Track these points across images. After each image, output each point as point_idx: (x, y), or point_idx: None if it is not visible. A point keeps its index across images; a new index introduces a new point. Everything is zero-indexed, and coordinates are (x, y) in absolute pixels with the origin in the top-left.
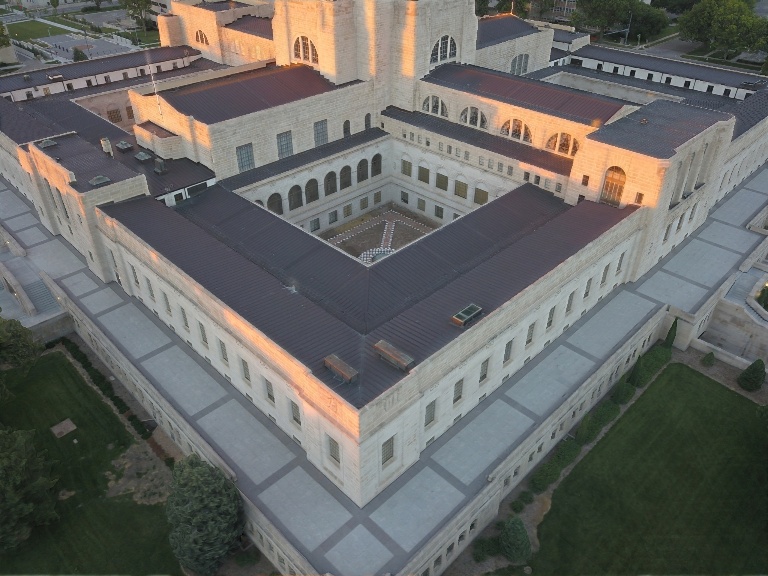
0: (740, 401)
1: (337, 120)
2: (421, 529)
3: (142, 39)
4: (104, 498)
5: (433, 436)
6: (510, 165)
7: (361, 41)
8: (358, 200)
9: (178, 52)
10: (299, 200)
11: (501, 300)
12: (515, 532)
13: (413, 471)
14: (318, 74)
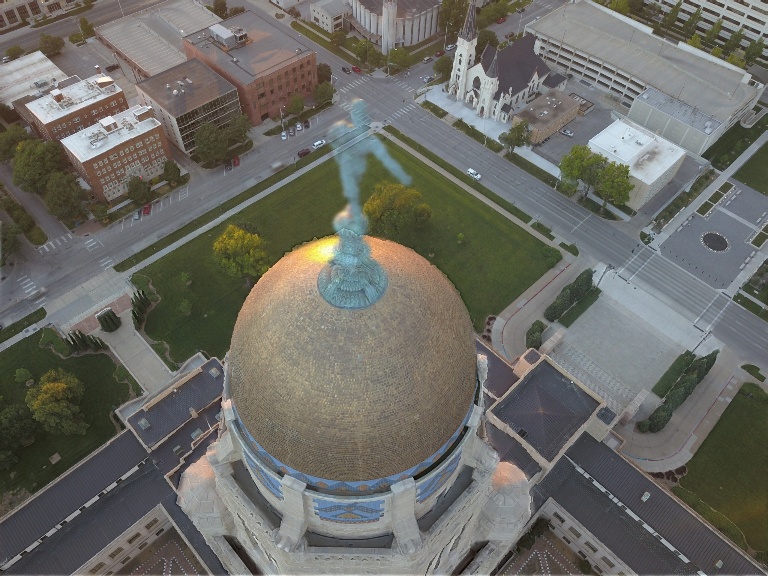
0: None
1: None
2: None
3: None
4: (4, 492)
5: None
6: None
7: None
8: None
9: (502, 382)
10: None
11: None
12: None
13: None
14: None
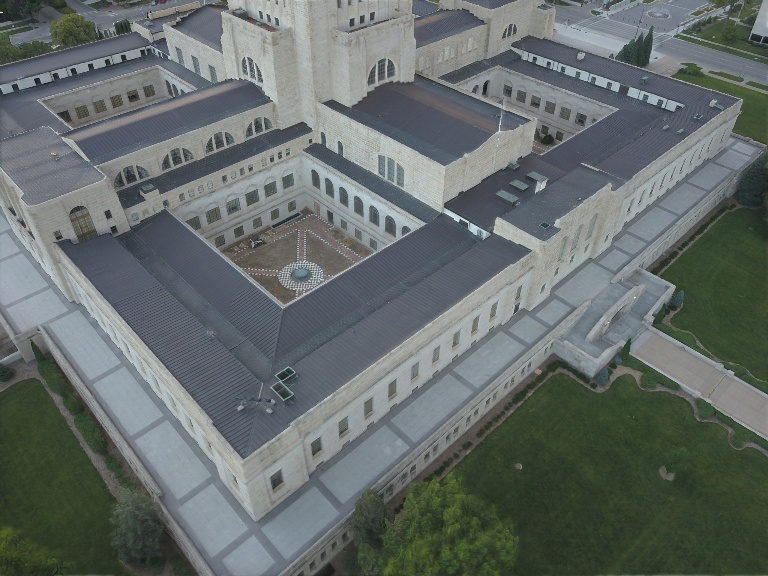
0: None
1: (221, 74)
2: None
3: None
4: None
5: None
6: None
7: None
8: None
9: None
10: None
11: None
12: None
13: None
14: None
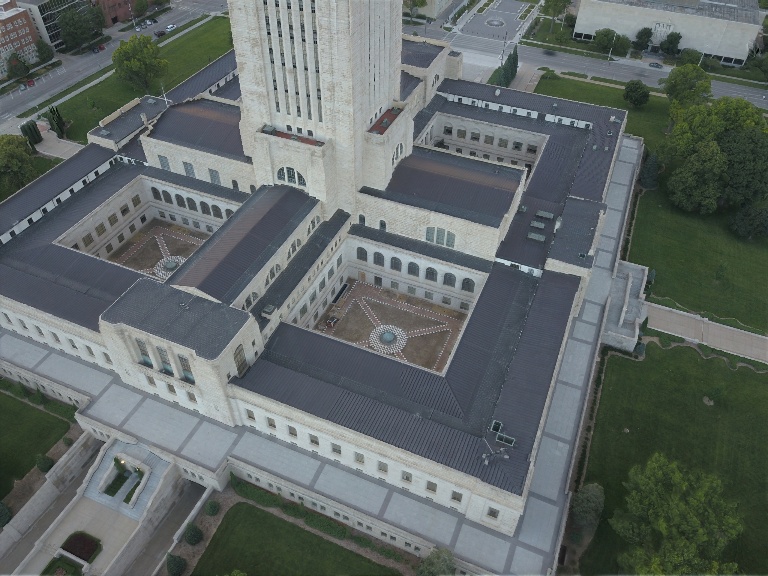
0: (32, 461)
1: (226, 176)
2: None
3: (540, 34)
4: None
5: None
6: None
7: None
8: None
9: None
10: None
11: None
12: None
13: None
14: None
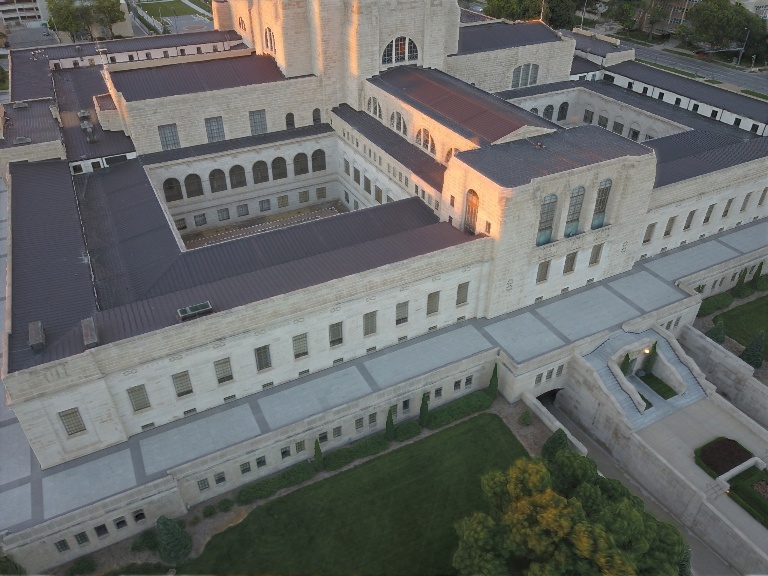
0: None
1: (278, 111)
2: (73, 502)
3: None
4: None
5: (152, 422)
6: (406, 176)
7: (313, 36)
8: (296, 193)
9: (223, 36)
10: (223, 184)
11: (244, 304)
12: (160, 531)
13: (113, 449)
14: (277, 65)
